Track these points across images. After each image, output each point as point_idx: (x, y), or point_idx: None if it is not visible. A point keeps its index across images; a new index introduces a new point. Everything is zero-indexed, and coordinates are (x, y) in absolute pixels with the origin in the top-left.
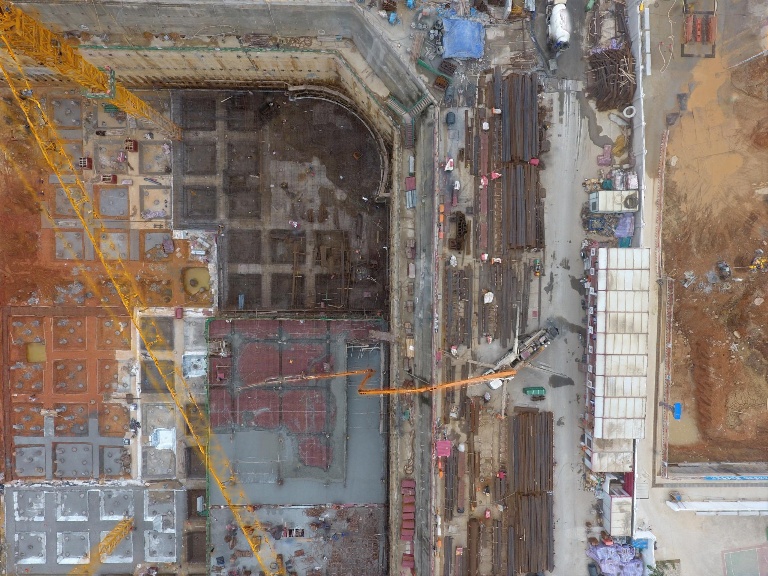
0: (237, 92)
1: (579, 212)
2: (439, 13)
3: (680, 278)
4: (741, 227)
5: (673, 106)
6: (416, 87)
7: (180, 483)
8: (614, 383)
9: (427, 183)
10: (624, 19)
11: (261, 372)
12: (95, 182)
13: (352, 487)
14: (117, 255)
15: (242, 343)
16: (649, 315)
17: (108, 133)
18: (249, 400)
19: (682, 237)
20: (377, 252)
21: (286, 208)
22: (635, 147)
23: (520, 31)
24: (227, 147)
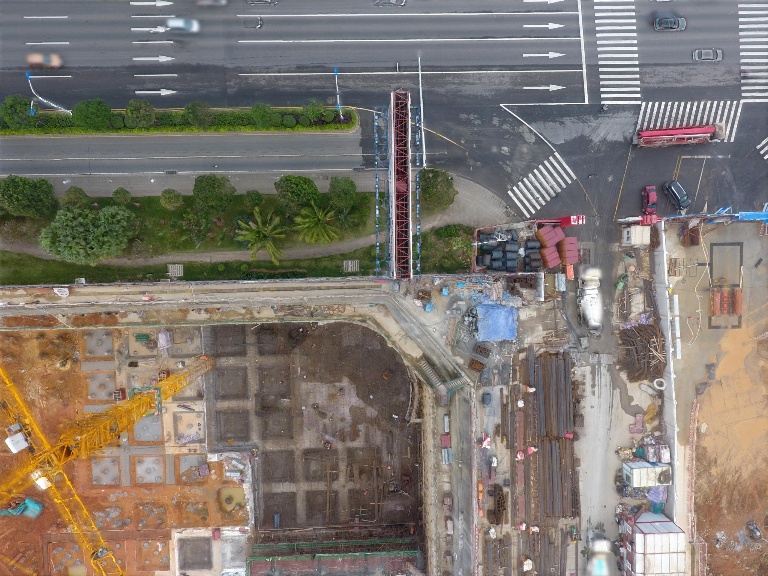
0: None
1: (613, 478)
2: (472, 298)
3: (712, 538)
4: None
5: (702, 376)
6: (451, 365)
7: None
8: None
9: (464, 452)
10: (653, 296)
11: None
12: None
13: None
14: (153, 478)
15: None
16: None
17: (140, 364)
18: None
19: (713, 499)
20: (409, 467)
21: (318, 428)
22: (666, 417)
23: (552, 311)
24: (258, 371)
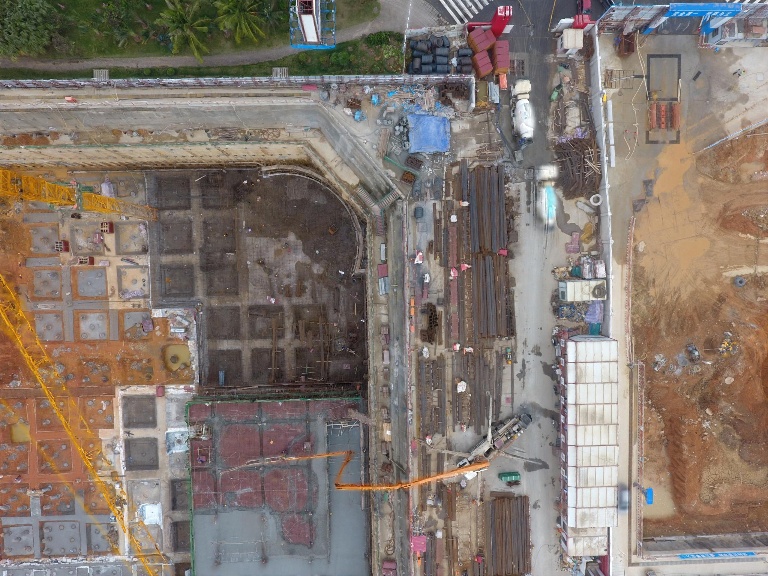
0: (211, 170)
1: (549, 299)
2: (404, 108)
3: (650, 361)
4: (709, 310)
5: (639, 193)
6: (384, 181)
7: (168, 557)
8: (586, 474)
9: (398, 274)
10: (588, 108)
11: (242, 453)
12: (72, 264)
13: (336, 562)
14: (97, 335)
15: (222, 425)
16: (621, 399)
17: (83, 216)
18: (231, 481)
19: (651, 321)
20: (355, 325)
21: (263, 284)
22: (602, 234)
23: (485, 123)
24: (203, 225)
